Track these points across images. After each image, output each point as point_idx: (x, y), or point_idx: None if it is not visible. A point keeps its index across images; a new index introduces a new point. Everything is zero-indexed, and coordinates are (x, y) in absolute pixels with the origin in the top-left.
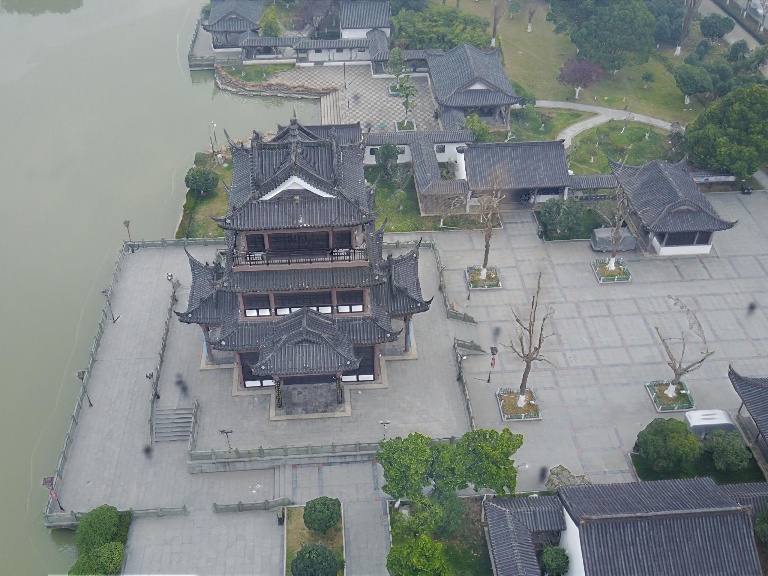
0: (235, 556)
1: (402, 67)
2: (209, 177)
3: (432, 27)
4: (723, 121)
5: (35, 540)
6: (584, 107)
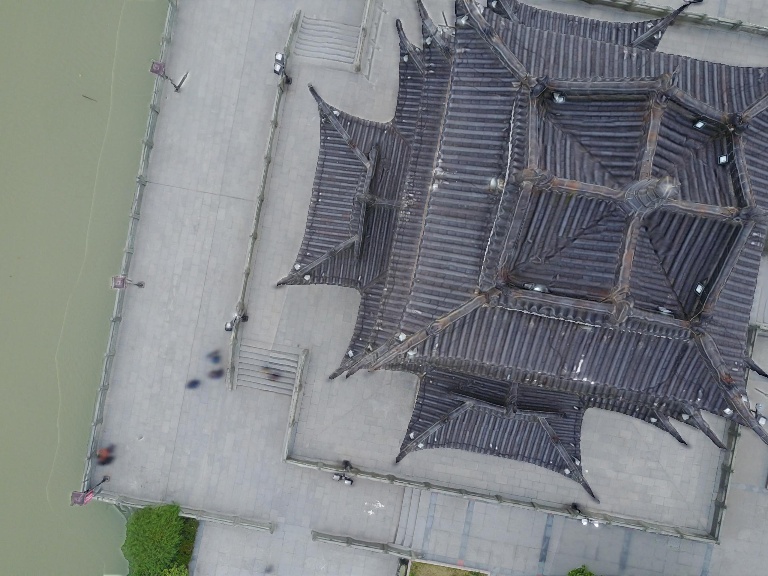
0: None
1: None
2: None
3: None
4: None
5: (72, 522)
6: None
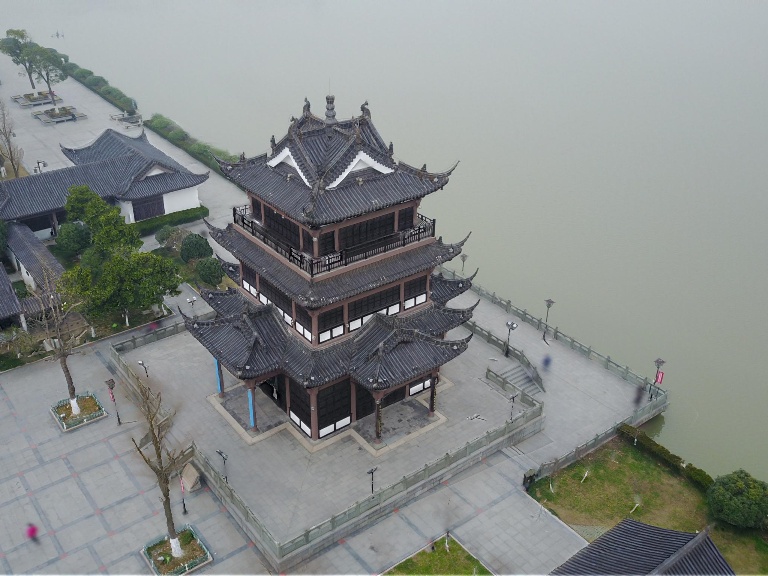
0: None
1: None
2: (718, 485)
3: None
4: None
5: None
6: None
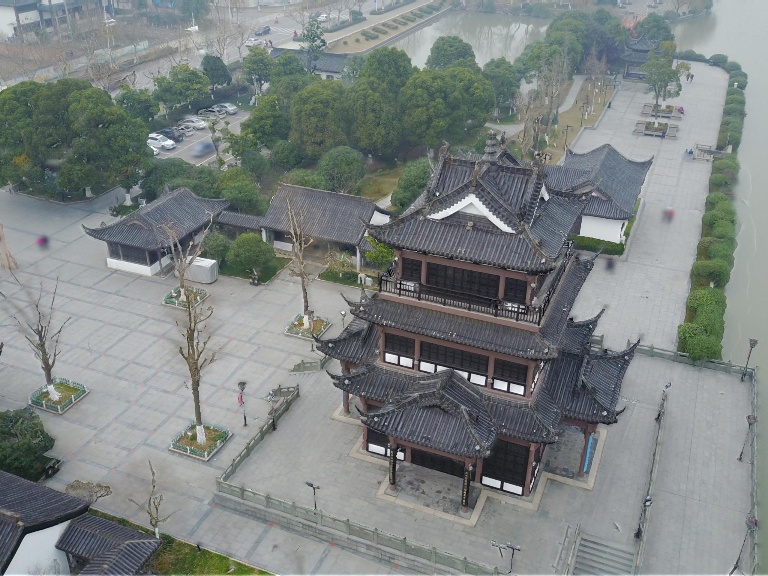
0: None
1: None
2: None
3: None
4: None
5: None
6: None
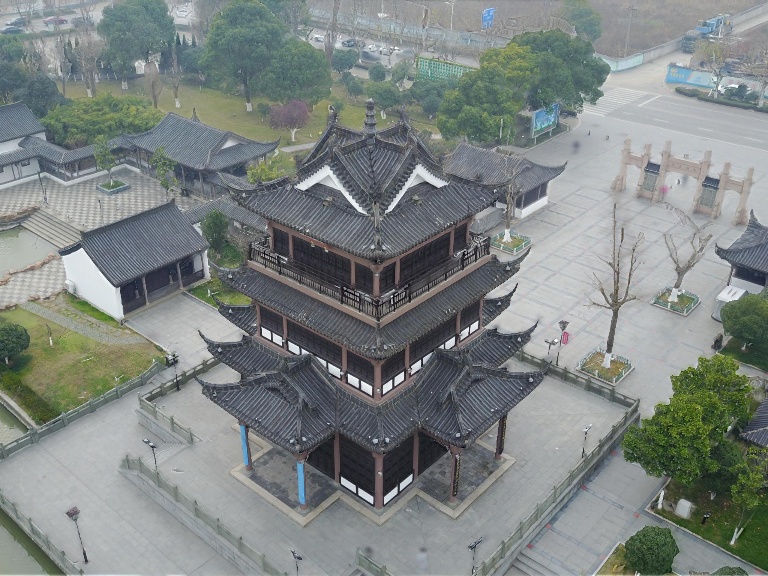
0: None
1: (113, 157)
2: (20, 332)
3: (101, 116)
4: (472, 102)
5: None
6: (310, 145)
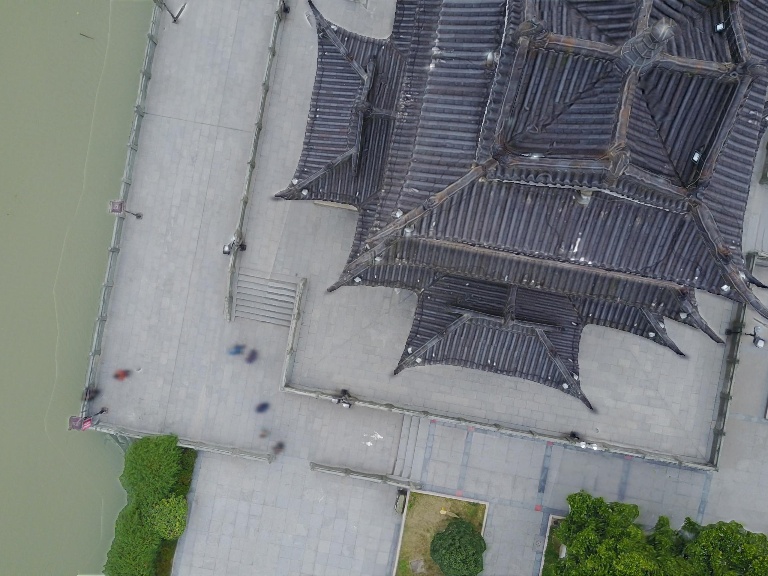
0: (331, 541)
1: None
2: None
3: None
4: None
5: (70, 453)
6: None
